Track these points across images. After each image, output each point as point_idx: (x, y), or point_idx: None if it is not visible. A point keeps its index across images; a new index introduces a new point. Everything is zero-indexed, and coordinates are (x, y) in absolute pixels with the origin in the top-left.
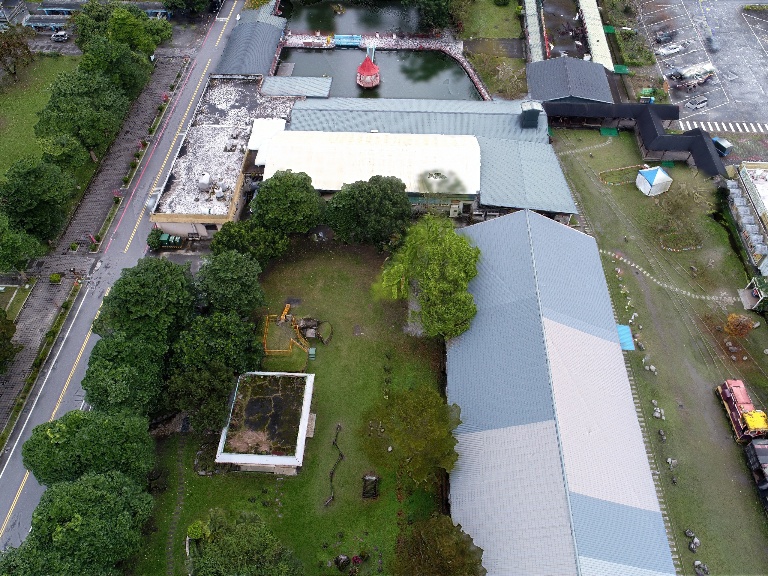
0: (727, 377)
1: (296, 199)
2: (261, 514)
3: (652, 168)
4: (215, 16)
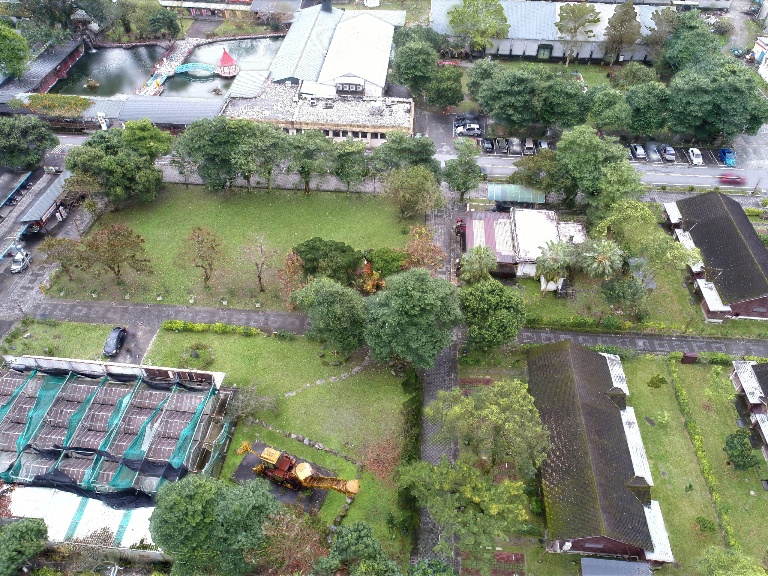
0: None
1: None
2: None
3: None
4: (46, 154)
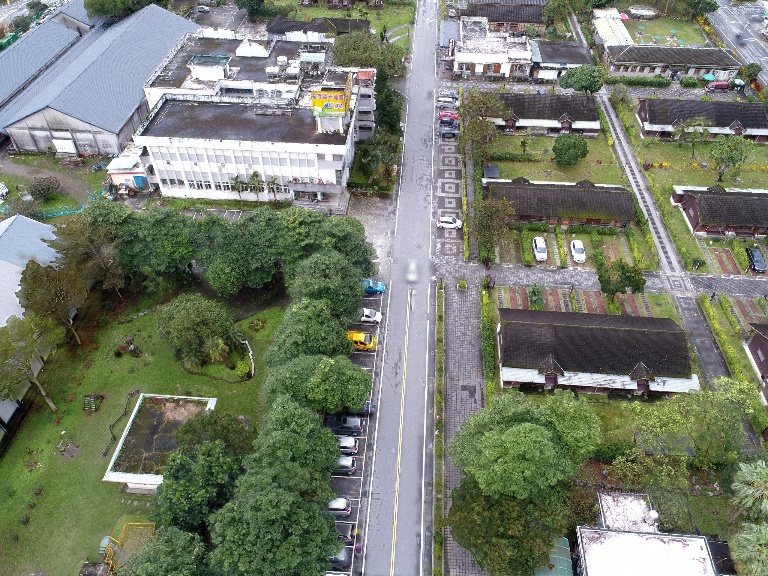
0: None
1: None
2: (193, 387)
3: None
4: None
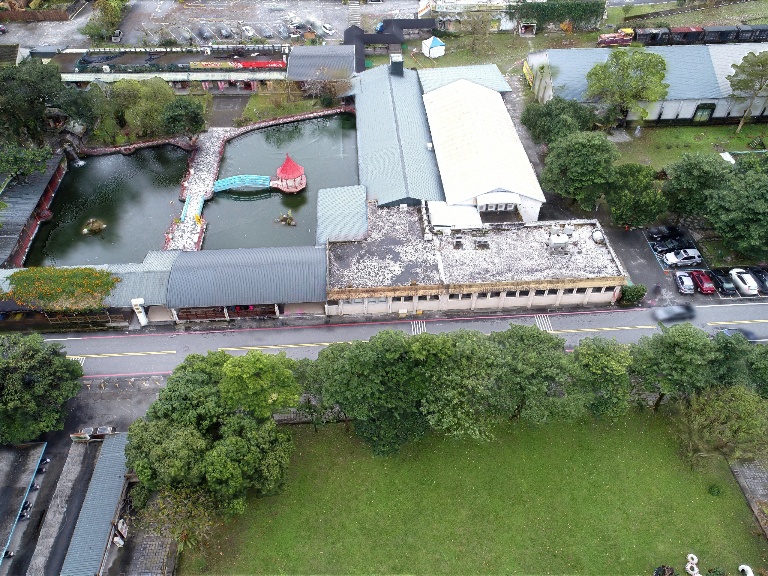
0: (588, 46)
1: None
2: None
3: (428, 42)
4: None
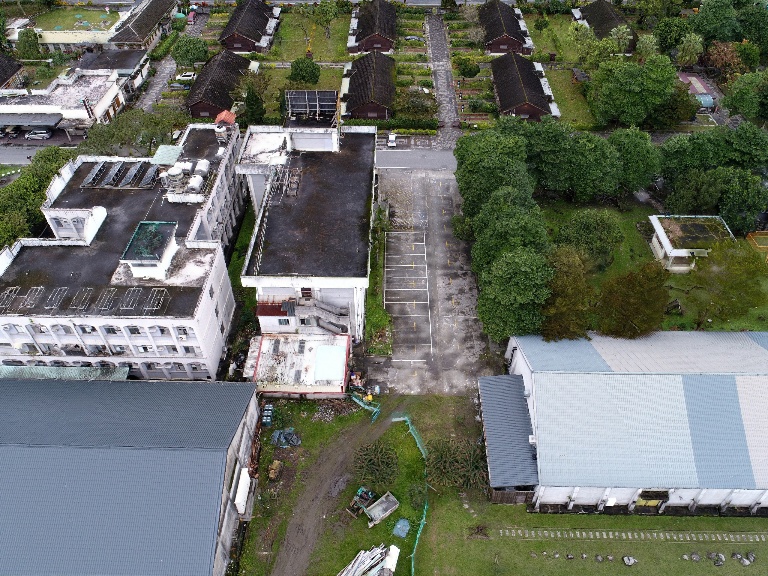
0: None
1: None
2: (625, 256)
3: None
4: None
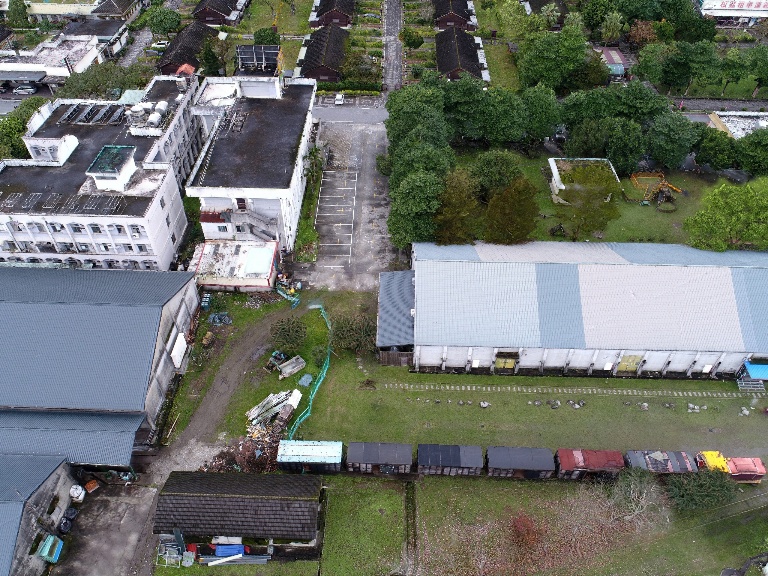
0: None
1: (763, 141)
2: None
3: None
4: None
